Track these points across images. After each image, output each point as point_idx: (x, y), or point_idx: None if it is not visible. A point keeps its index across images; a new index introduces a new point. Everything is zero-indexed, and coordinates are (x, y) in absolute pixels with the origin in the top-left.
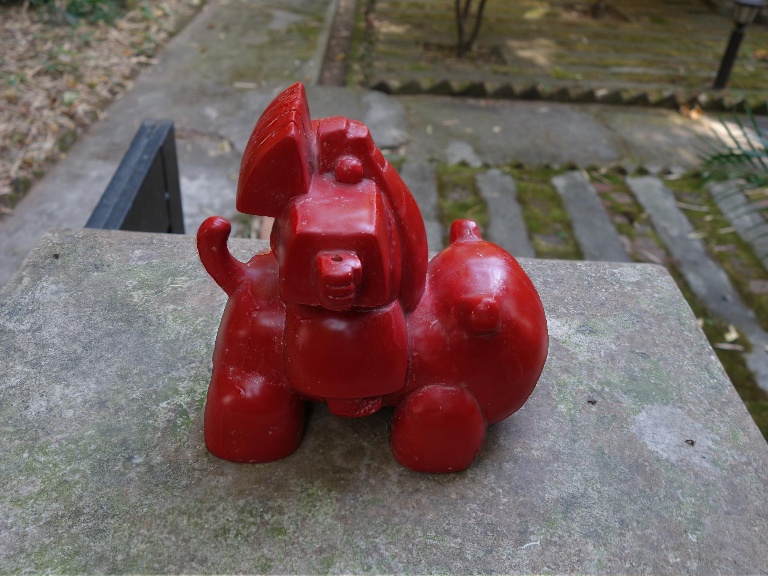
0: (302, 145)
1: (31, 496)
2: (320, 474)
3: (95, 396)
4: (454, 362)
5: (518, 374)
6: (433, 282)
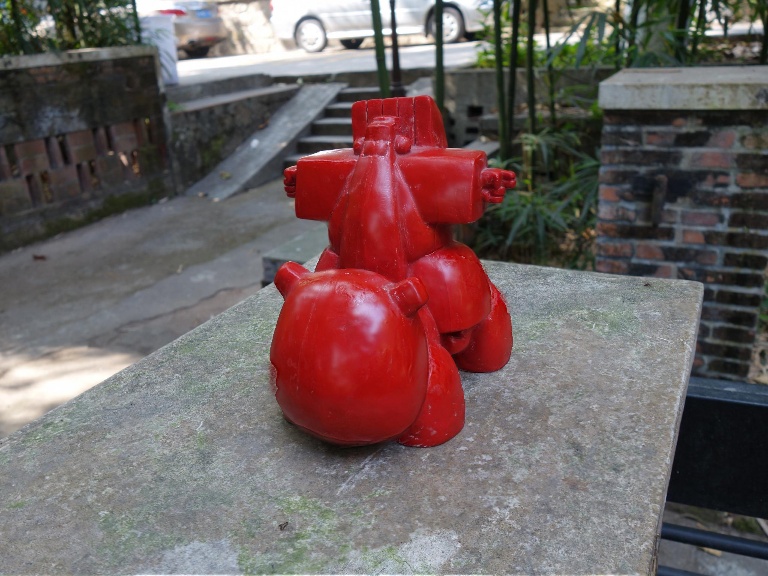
0: (368, 120)
1: None
2: None
3: None
4: None
5: None
6: None
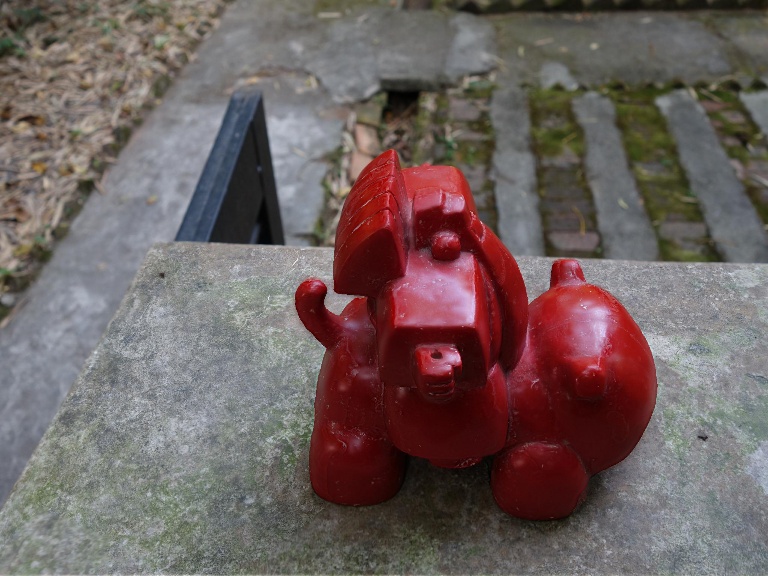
0: (397, 228)
1: (157, 538)
2: (422, 519)
3: (207, 430)
4: (556, 421)
5: (624, 432)
6: (534, 336)
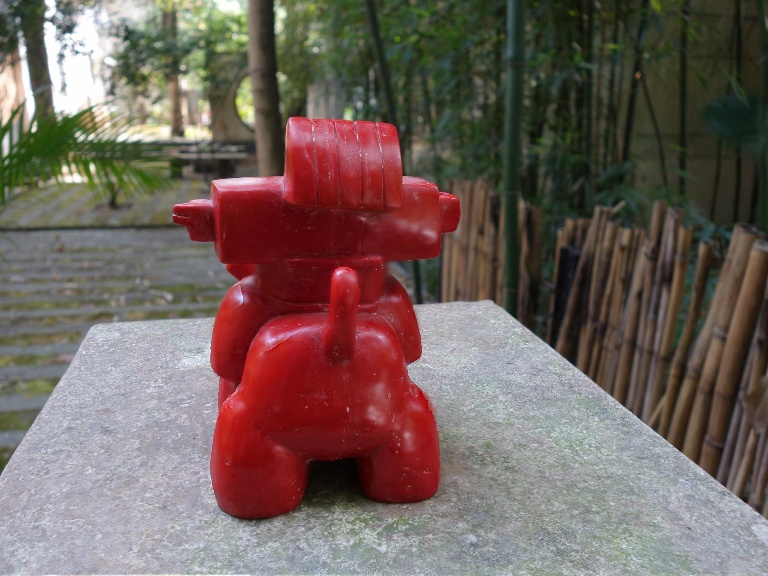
0: None
1: None
2: None
3: None
4: None
5: None
6: None
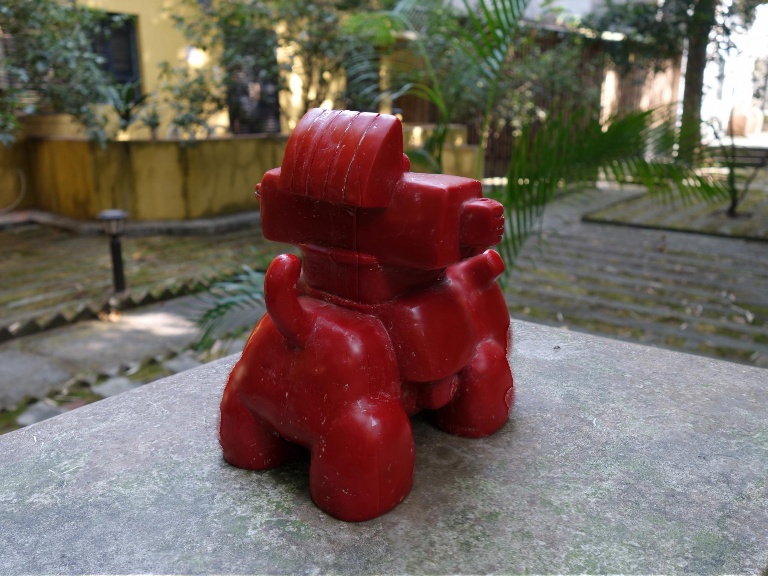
0: None
1: None
2: (449, 475)
3: None
4: (481, 319)
5: None
6: None
